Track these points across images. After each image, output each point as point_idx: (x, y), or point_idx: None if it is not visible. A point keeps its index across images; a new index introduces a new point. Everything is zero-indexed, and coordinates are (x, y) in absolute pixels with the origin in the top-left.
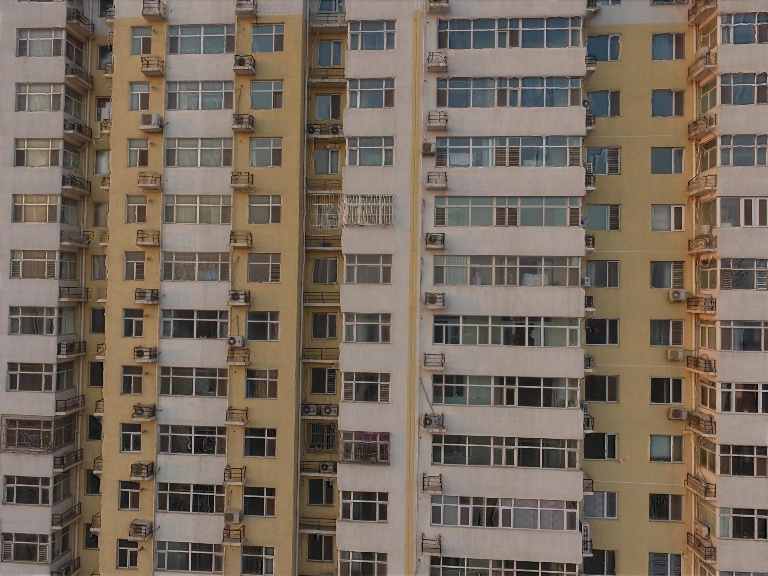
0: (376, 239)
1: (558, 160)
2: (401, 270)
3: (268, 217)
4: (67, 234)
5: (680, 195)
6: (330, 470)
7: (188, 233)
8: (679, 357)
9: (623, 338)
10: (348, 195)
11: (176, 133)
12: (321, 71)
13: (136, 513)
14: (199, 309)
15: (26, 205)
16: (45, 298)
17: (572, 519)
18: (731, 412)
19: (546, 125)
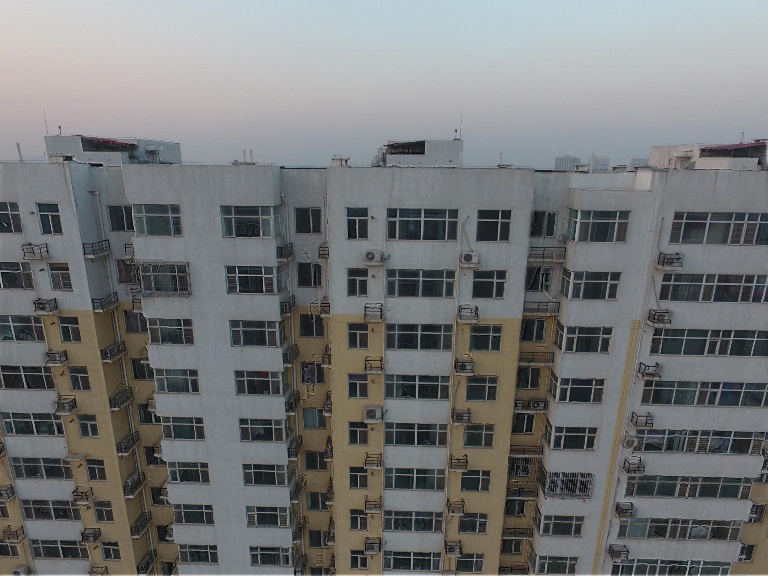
0: (573, 506)
1: (741, 448)
2: (592, 528)
3: (477, 485)
4: (293, 490)
5: None
6: None
7: (406, 497)
8: None
9: (756, 558)
10: (552, 473)
11: (395, 419)
12: (528, 355)
13: None
14: (416, 552)
15: (255, 472)
16: (281, 542)
17: None
18: None
19: (738, 422)
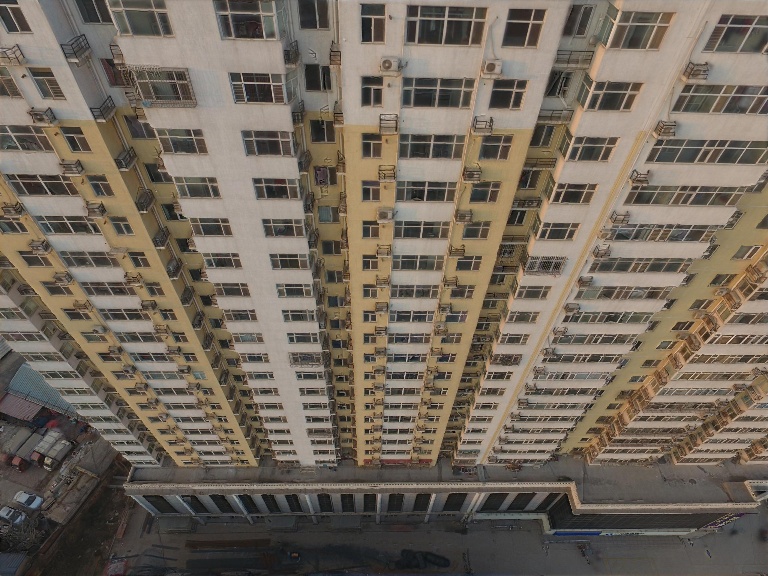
0: (545, 279)
1: (694, 237)
2: (556, 294)
3: (470, 266)
4: (314, 271)
5: (765, 241)
6: (480, 359)
7: (410, 276)
8: (701, 317)
9: (674, 307)
10: (533, 257)
11: (404, 218)
12: (532, 160)
13: (374, 381)
14: (416, 311)
15: (281, 259)
16: (307, 306)
17: (604, 376)
18: (712, 344)
19: (700, 218)
